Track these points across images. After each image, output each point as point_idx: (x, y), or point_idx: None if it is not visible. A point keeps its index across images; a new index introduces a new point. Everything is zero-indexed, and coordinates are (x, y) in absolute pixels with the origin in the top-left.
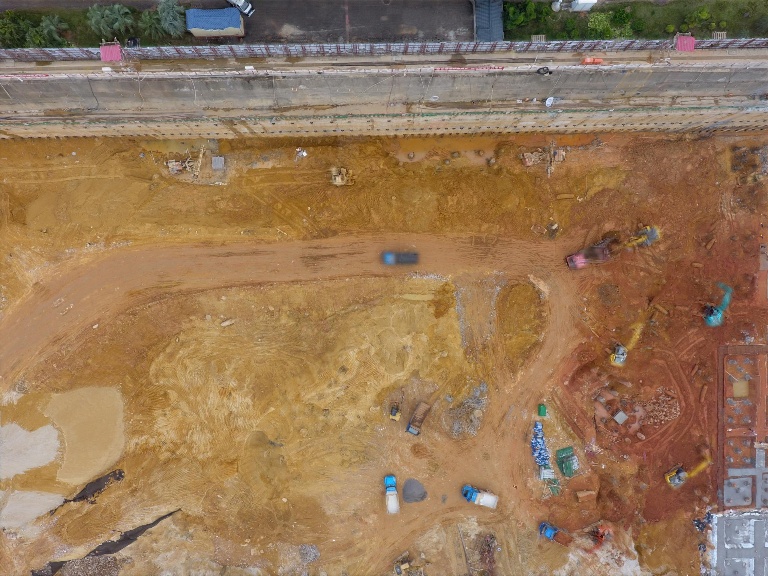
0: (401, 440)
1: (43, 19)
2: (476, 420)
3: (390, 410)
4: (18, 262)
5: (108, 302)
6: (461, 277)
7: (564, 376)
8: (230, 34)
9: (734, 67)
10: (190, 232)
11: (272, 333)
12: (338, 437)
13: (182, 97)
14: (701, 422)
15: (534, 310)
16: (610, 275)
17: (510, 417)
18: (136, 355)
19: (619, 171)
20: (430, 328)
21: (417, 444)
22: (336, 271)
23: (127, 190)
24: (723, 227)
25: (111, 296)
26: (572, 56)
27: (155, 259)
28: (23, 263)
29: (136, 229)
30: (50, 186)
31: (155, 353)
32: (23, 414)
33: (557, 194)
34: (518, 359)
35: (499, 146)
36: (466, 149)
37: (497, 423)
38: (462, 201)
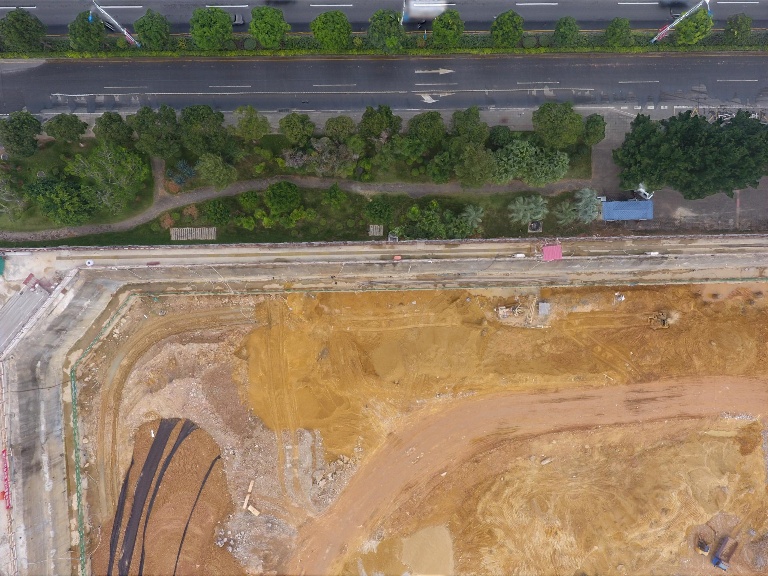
0: (704, 572)
1: (471, 212)
2: None
3: (696, 544)
4: (373, 413)
5: (455, 450)
6: None
7: None
8: (631, 219)
9: None
10: (528, 380)
11: (585, 469)
12: (649, 571)
13: (563, 269)
14: None
15: None
16: None
17: None
18: (465, 494)
19: None
20: (738, 466)
21: (720, 575)
22: (656, 414)
23: (469, 340)
24: None
25: (458, 445)
26: None
27: (496, 407)
28: (378, 414)
29: (481, 379)
30: (391, 334)
31: (480, 491)
32: (386, 563)
33: None
34: None
35: None
36: (767, 289)
37: None
38: None
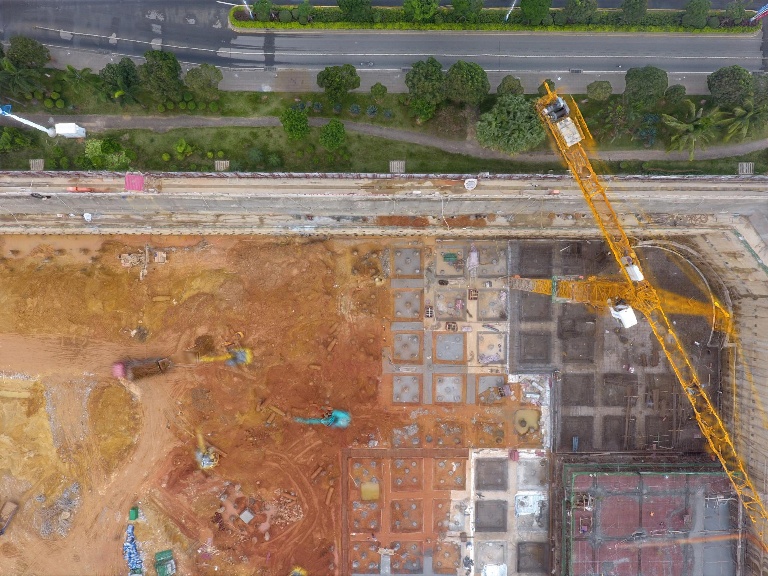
0: None
1: None
2: (62, 522)
3: None
4: None
5: None
6: (50, 377)
7: (159, 479)
8: None
9: (235, 196)
10: None
11: None
12: None
13: None
14: (323, 525)
15: (128, 412)
16: (203, 379)
17: (103, 519)
18: None
19: (220, 274)
20: (18, 427)
21: (7, 543)
22: None
23: None
24: (344, 329)
25: None
26: (68, 181)
27: None
28: None
29: None
30: None
31: None
32: None
33: (154, 296)
34: (115, 460)
35: (103, 245)
36: (72, 247)
37: (89, 524)
38: (41, 304)
